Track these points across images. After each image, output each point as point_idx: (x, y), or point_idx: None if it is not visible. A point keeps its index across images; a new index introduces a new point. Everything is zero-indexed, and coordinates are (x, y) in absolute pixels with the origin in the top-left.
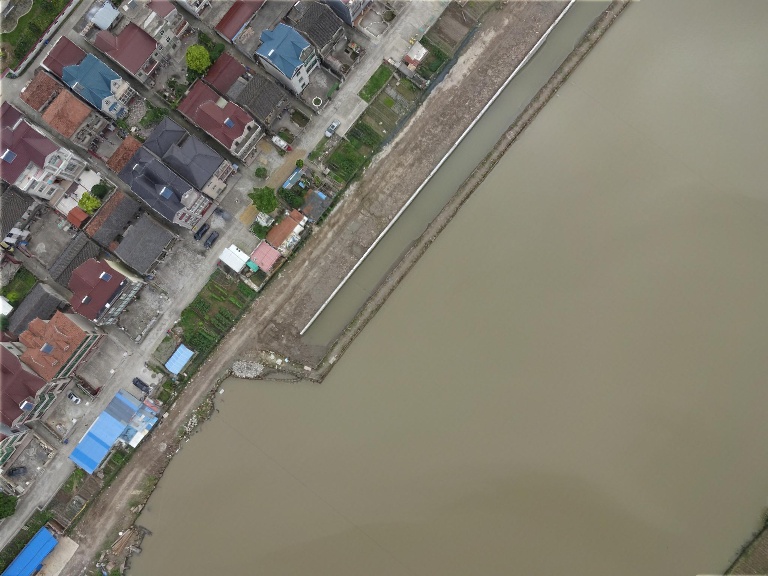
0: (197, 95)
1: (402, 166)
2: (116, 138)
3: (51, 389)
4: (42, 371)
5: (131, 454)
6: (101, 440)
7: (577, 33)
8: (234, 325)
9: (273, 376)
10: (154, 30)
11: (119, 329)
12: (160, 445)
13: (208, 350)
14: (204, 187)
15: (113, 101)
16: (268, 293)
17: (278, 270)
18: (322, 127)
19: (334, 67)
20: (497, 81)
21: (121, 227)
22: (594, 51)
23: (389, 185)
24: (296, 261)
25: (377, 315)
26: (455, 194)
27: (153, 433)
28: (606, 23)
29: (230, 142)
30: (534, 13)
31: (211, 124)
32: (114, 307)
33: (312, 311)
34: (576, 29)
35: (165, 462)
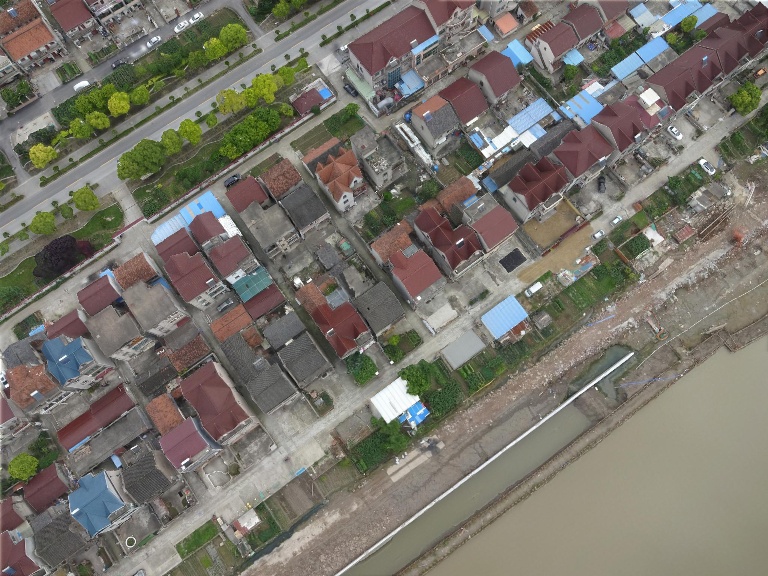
0: None
1: None
2: None
3: None
4: None
5: None
6: None
7: (428, 537)
8: None
9: None
10: None
11: None
12: None
13: None
14: None
15: None
16: None
17: None
18: (126, 572)
19: (157, 514)
20: (327, 570)
21: None
22: (438, 569)
23: None
24: None
25: None
26: None
27: None
28: (458, 541)
29: None
30: (387, 506)
31: None
32: None
33: None
34: (428, 533)
35: None
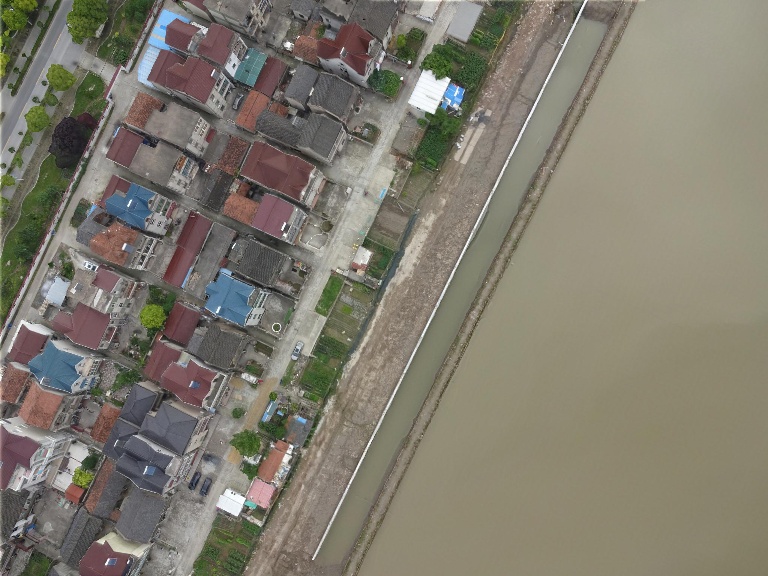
0: (159, 357)
1: (374, 370)
2: (94, 405)
3: None
4: None
5: None
6: None
7: (518, 194)
8: (246, 564)
9: None
10: (104, 307)
11: None
12: None
13: None
14: (185, 451)
15: (82, 379)
16: (272, 525)
17: (277, 500)
18: (287, 351)
19: (285, 292)
20: (448, 263)
21: (117, 495)
22: (538, 211)
23: (365, 392)
24: (292, 487)
25: (383, 524)
26: (432, 387)
27: None
28: (544, 180)
29: (200, 402)
30: (470, 186)
31: (178, 388)
32: None
33: (319, 533)
34: (516, 190)
35: None
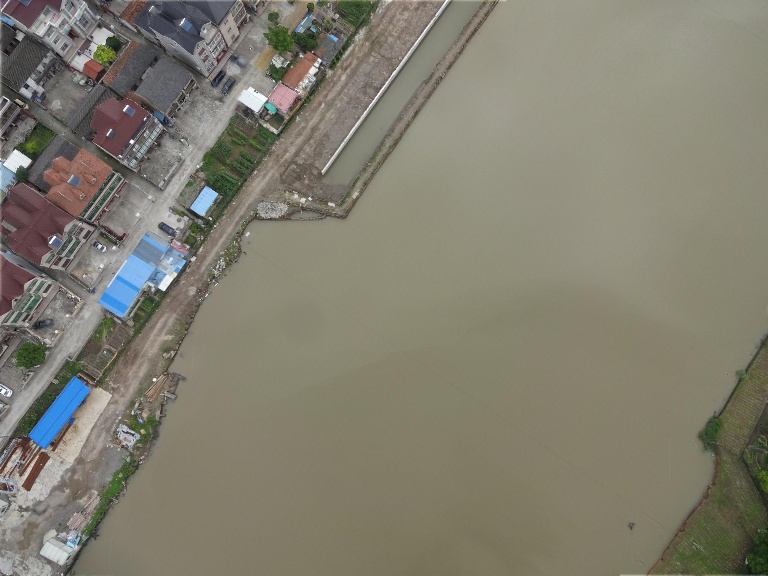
0: None
1: (408, 10)
2: None
3: (77, 232)
4: (69, 206)
5: (160, 301)
6: (130, 283)
7: None
8: (256, 168)
9: (298, 216)
10: None
11: (141, 177)
12: (189, 289)
13: (232, 193)
14: (221, 22)
15: None
16: (287, 136)
17: (295, 113)
18: None
19: None
20: None
21: (138, 76)
22: None
23: (397, 28)
24: (312, 104)
25: (395, 151)
26: (460, 33)
27: (181, 278)
28: None
29: None
30: None
31: None
32: (138, 145)
33: (331, 151)
34: None
35: (195, 306)
